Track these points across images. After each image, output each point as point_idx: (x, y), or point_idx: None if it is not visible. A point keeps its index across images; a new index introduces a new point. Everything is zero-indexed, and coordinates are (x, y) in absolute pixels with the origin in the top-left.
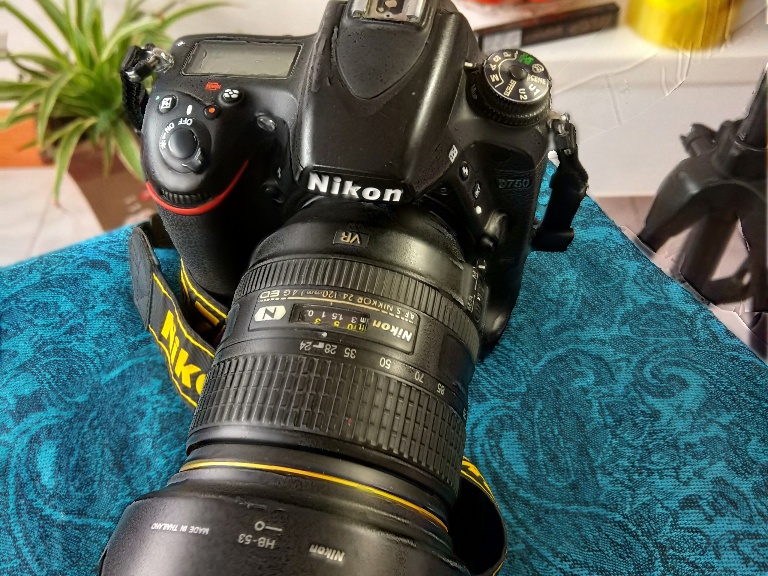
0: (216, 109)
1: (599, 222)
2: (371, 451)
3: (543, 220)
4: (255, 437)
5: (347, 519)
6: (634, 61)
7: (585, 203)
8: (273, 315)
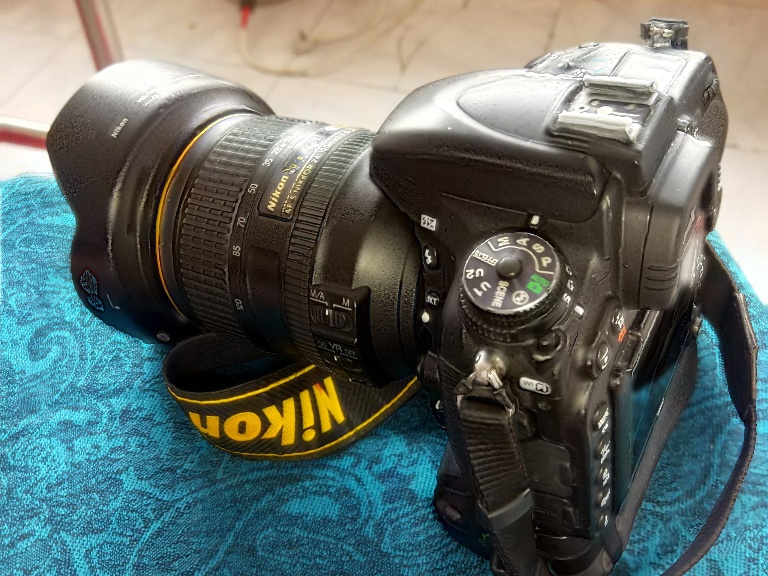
0: (562, 67)
1: None
2: (193, 180)
3: None
4: (240, 121)
5: (139, 145)
6: None
7: None
8: (333, 127)
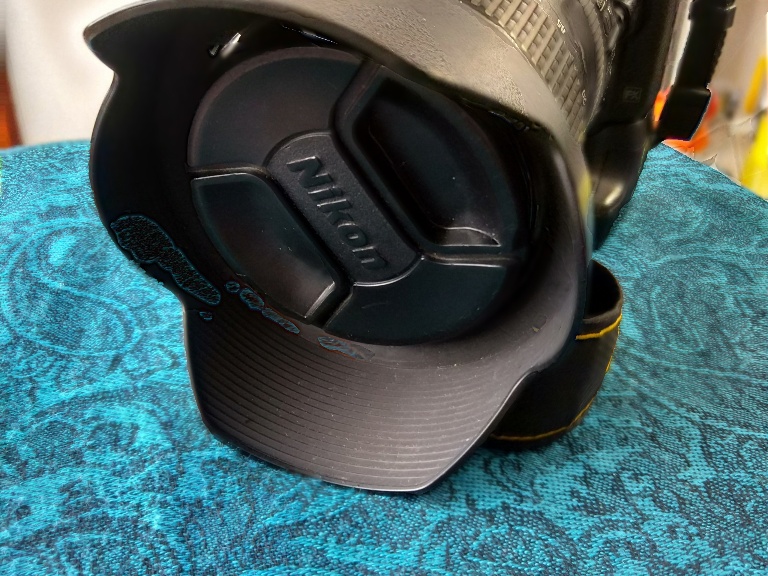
0: None
1: (727, 182)
2: (470, 8)
3: (674, 78)
4: None
5: None
6: (759, 107)
7: (710, 169)
8: None
